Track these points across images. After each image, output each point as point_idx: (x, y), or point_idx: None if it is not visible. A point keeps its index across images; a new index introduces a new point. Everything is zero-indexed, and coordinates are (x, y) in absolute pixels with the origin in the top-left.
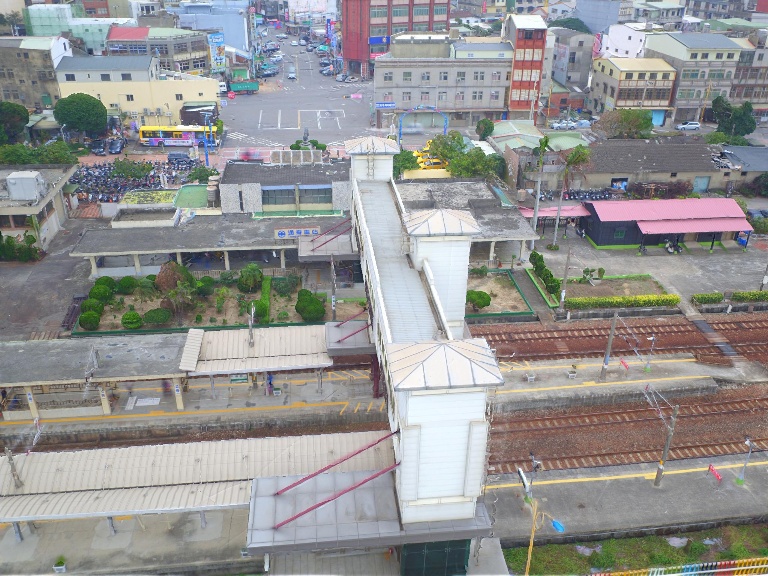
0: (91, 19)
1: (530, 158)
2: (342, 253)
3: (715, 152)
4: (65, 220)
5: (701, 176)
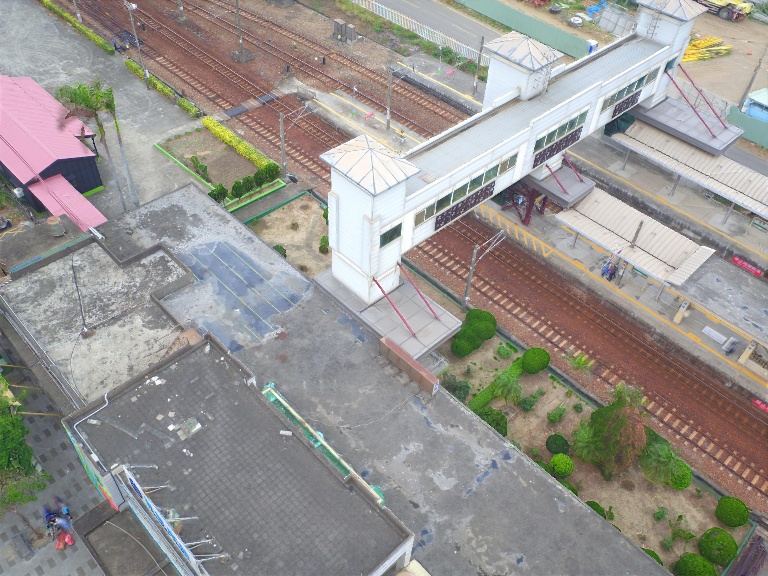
0: None
1: None
2: None
3: None
4: None
5: None
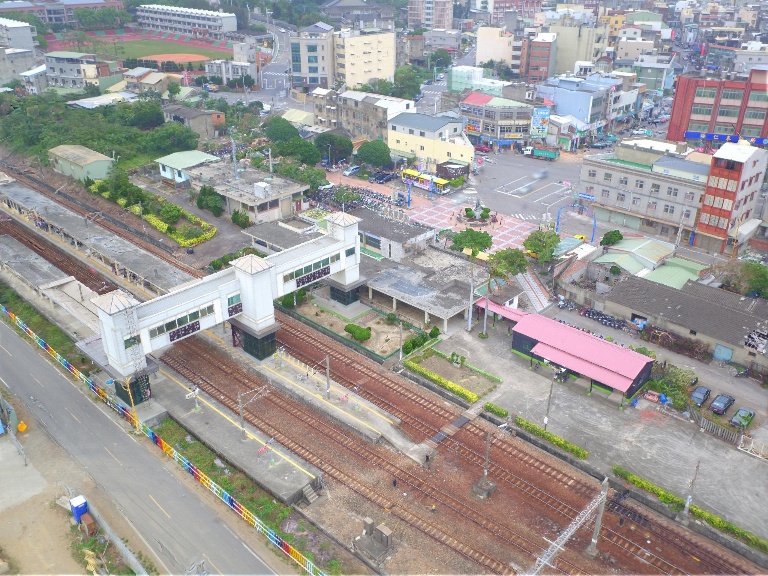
0: (491, 81)
1: (608, 274)
2: None
3: (762, 329)
4: (289, 214)
5: (724, 345)
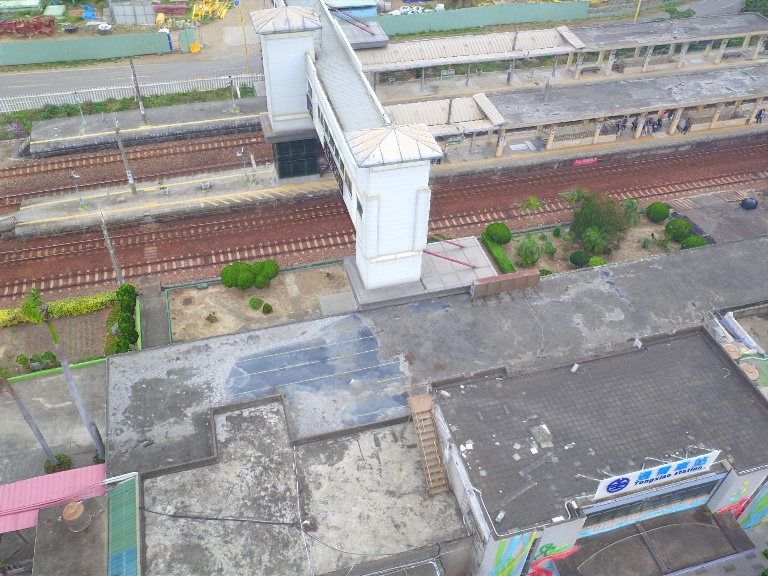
0: None
1: None
2: None
3: None
4: None
5: None
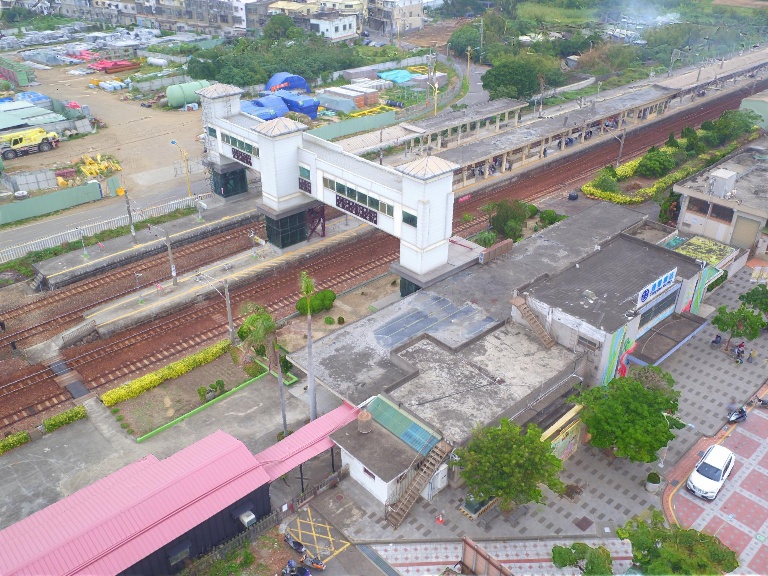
0: None
1: None
2: None
3: None
4: None
5: None
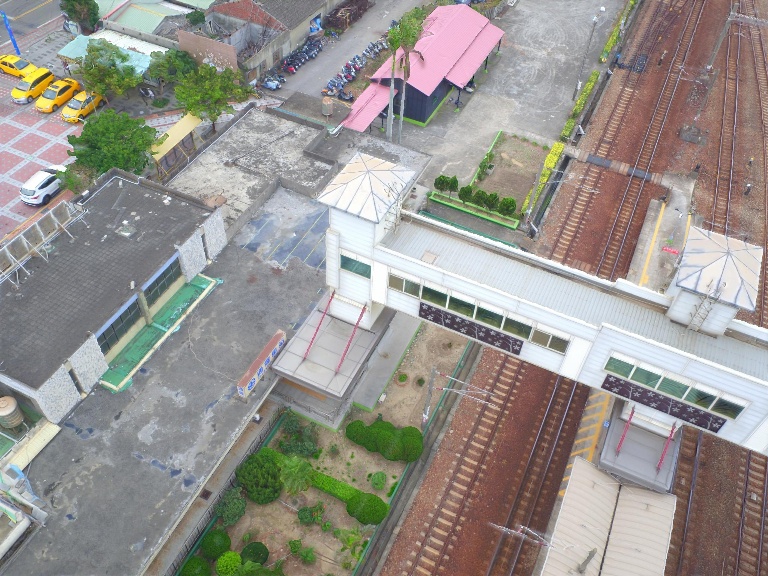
0: None
1: (189, 31)
2: (369, 345)
3: None
4: None
5: None
